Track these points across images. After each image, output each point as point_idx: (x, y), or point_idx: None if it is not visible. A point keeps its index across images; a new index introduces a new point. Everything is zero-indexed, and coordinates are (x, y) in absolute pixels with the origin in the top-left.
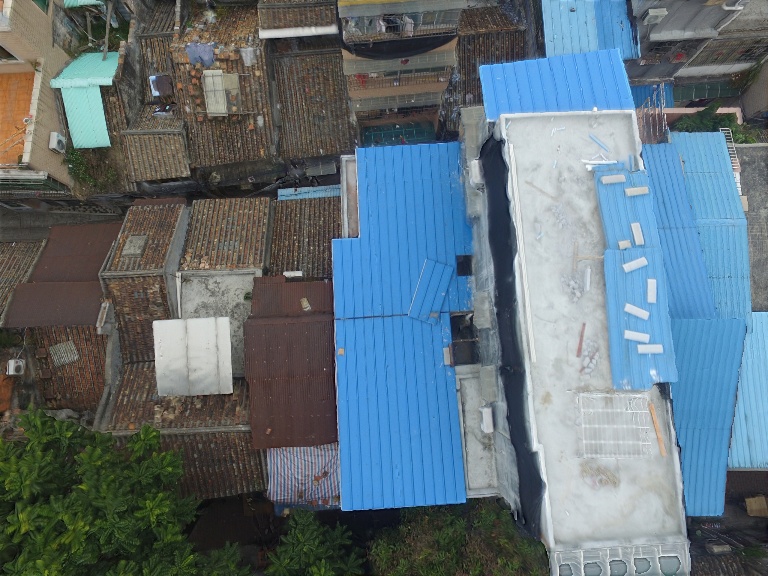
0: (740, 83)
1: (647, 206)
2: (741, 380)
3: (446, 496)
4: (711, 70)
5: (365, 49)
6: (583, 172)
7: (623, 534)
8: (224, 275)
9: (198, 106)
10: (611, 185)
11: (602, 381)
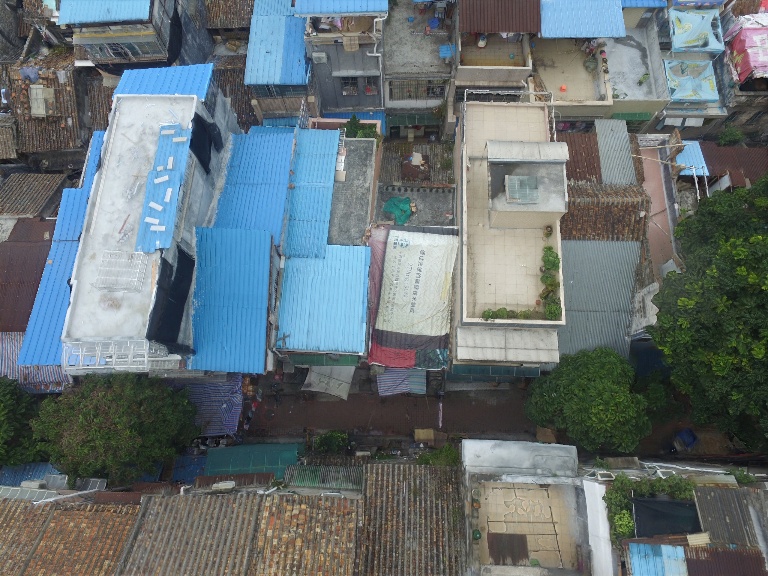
0: (438, 114)
1: (184, 148)
2: (311, 290)
3: (91, 359)
4: (414, 104)
5: (112, 69)
6: (158, 129)
7: None
8: (7, 219)
9: (26, 109)
10: (166, 136)
11: (129, 248)
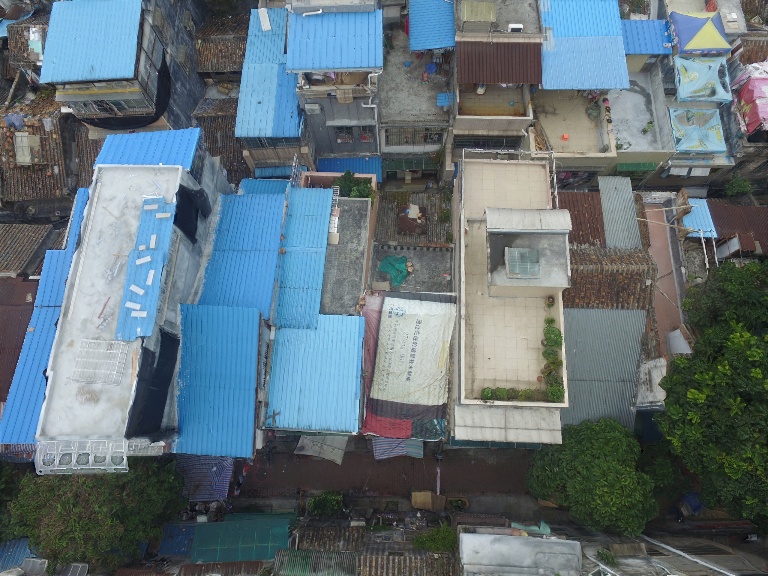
0: (436, 159)
1: (168, 225)
2: (302, 363)
3: None
4: (411, 149)
5: (98, 122)
6: (141, 202)
7: (89, 433)
8: None
9: (11, 157)
10: (149, 211)
11: (109, 334)
